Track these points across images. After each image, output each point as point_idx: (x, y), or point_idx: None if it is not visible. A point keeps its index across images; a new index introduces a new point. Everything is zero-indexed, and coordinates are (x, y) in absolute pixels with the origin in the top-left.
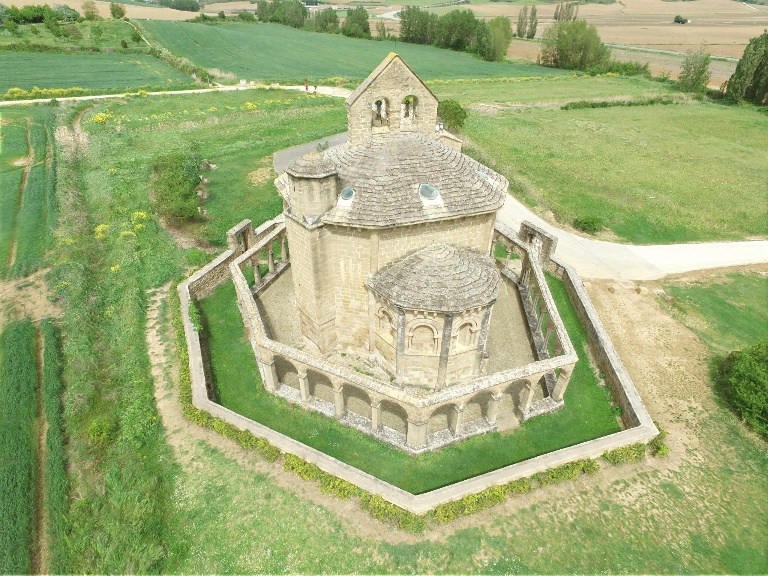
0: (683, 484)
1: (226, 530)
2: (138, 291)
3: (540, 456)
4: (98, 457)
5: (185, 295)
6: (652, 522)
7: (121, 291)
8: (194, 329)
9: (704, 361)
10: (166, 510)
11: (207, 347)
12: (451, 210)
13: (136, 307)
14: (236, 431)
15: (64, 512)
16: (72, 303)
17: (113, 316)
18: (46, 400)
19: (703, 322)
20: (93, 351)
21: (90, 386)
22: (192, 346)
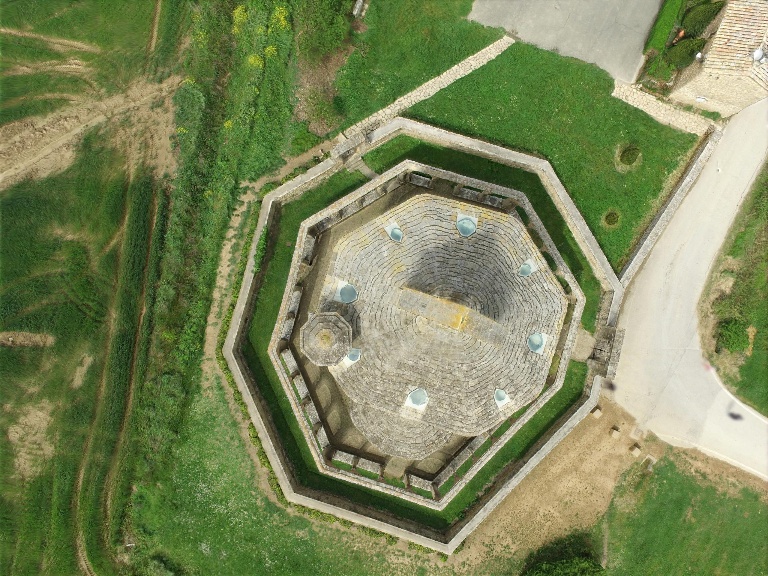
0: (433, 573)
1: (206, 442)
2: (232, 186)
3: (372, 519)
4: (166, 350)
5: (264, 216)
6: (391, 575)
7: (222, 170)
8: (252, 270)
9: (573, 530)
10: (185, 413)
11: (265, 271)
12: (424, 420)
13: (224, 211)
14: (235, 389)
15: (140, 388)
16: (184, 164)
17: (209, 200)
18: (146, 289)
19: (633, 506)
20: (183, 248)
21: (172, 292)
22: (243, 290)
